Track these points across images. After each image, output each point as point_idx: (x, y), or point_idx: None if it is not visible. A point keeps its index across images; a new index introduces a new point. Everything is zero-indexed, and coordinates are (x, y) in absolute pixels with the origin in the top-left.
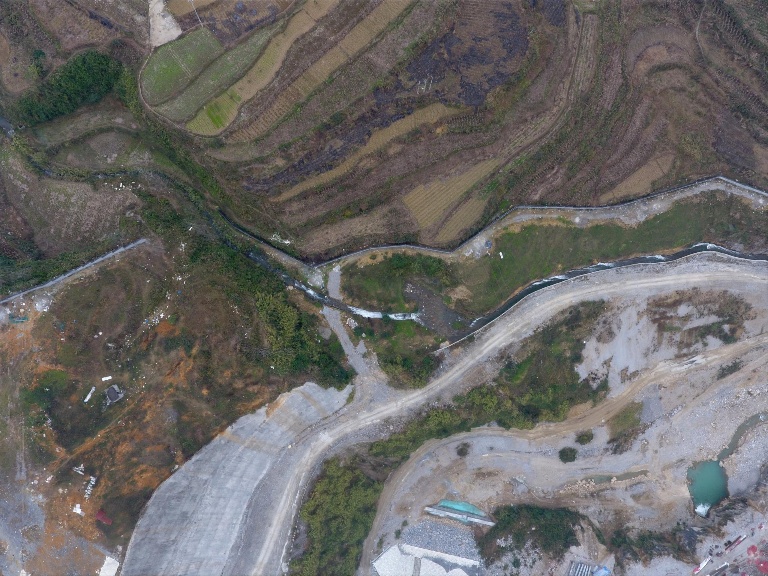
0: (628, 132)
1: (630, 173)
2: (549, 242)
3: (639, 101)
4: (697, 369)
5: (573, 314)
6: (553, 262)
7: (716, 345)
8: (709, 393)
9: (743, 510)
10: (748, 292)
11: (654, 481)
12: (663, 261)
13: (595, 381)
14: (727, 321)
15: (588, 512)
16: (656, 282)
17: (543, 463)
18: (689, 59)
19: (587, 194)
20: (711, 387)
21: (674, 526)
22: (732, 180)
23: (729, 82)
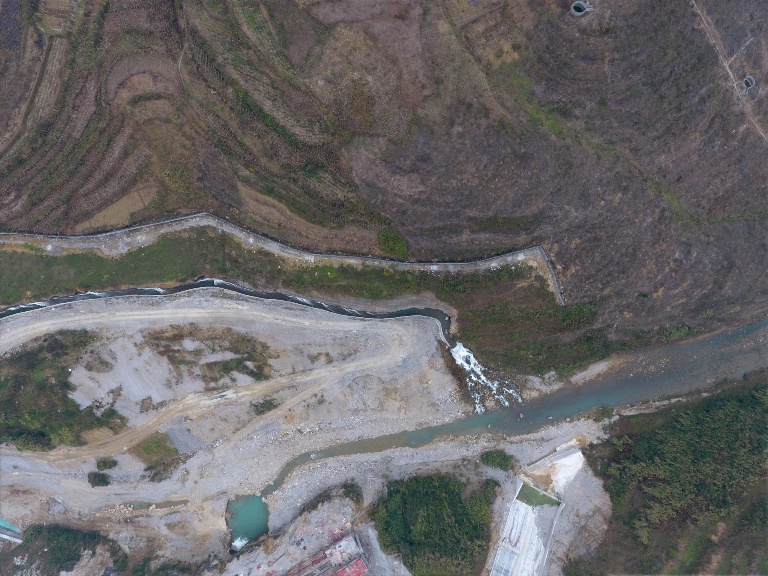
0: (105, 161)
1: (108, 203)
2: (15, 268)
3: (118, 130)
4: (226, 404)
5: (49, 342)
6: (21, 289)
7: (247, 381)
8: (250, 428)
9: (258, 548)
10: (256, 331)
11: (191, 511)
12: (159, 294)
13: (99, 409)
14: (247, 358)
15: (119, 537)
16: (149, 315)
17: (74, 485)
18: (175, 90)
19: (54, 222)
20: (252, 422)
21: (205, 558)
22: (218, 217)
23: (210, 116)
